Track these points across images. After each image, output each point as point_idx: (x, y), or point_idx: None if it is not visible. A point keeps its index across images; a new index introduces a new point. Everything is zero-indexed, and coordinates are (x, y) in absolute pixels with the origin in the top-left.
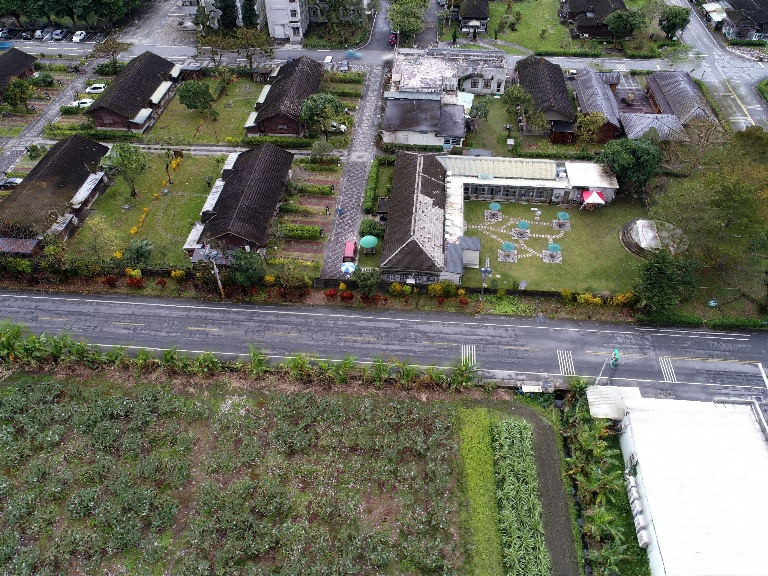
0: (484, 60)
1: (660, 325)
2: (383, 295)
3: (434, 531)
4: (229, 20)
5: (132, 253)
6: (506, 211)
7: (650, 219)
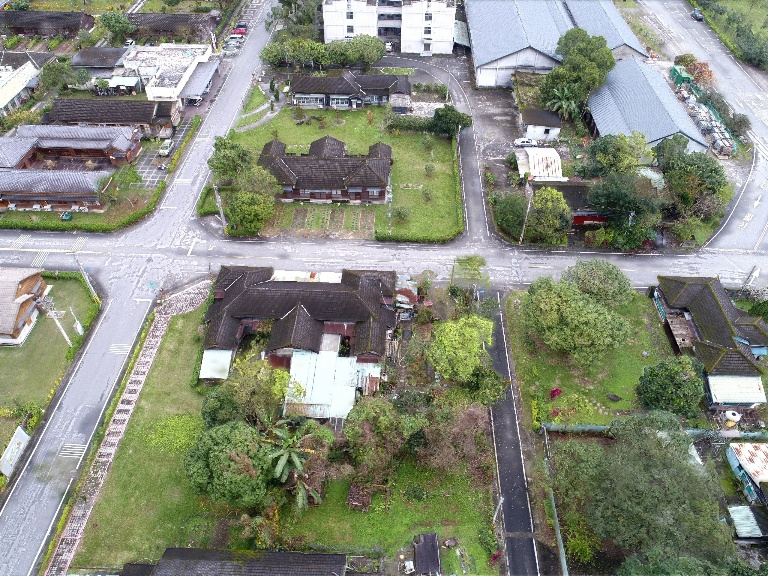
0: None
1: None
2: None
3: None
4: None
5: None
6: None
7: None
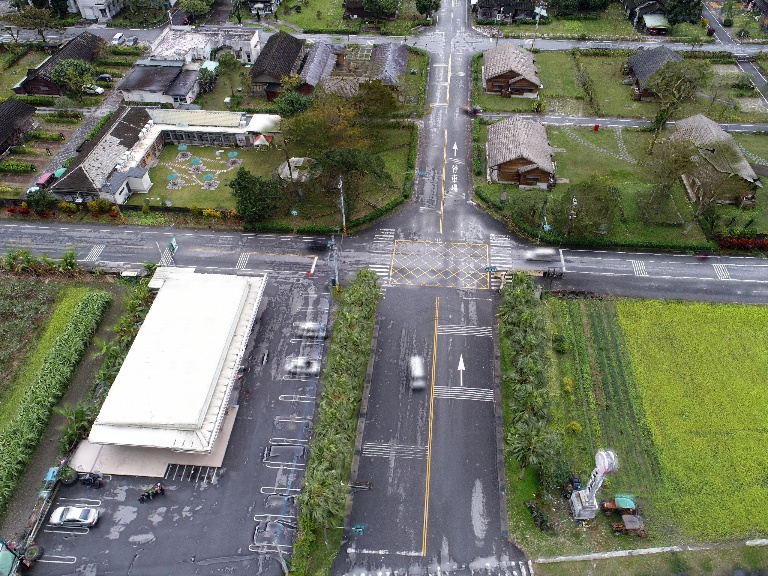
0: (240, 35)
1: (259, 231)
2: (58, 212)
3: (1, 363)
4: (38, 2)
5: None
6: (197, 153)
7: (302, 157)
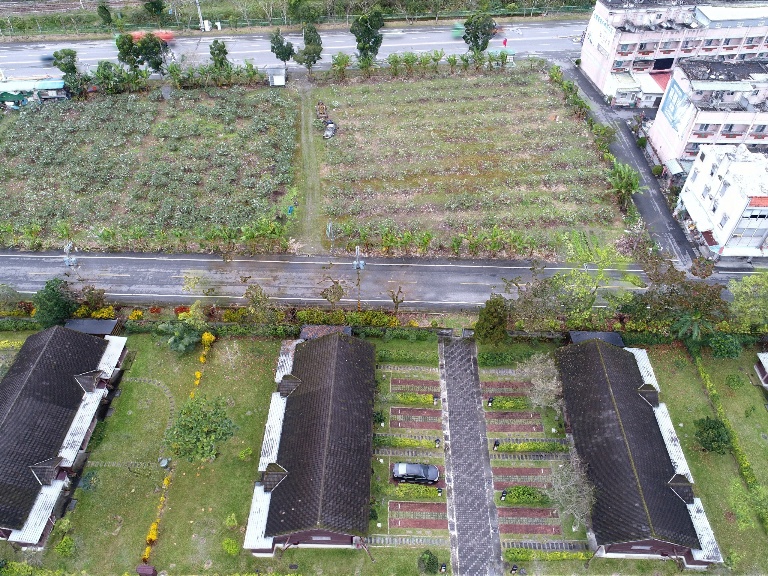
0: None
1: None
2: None
3: None
4: None
5: (186, 329)
6: None
7: None
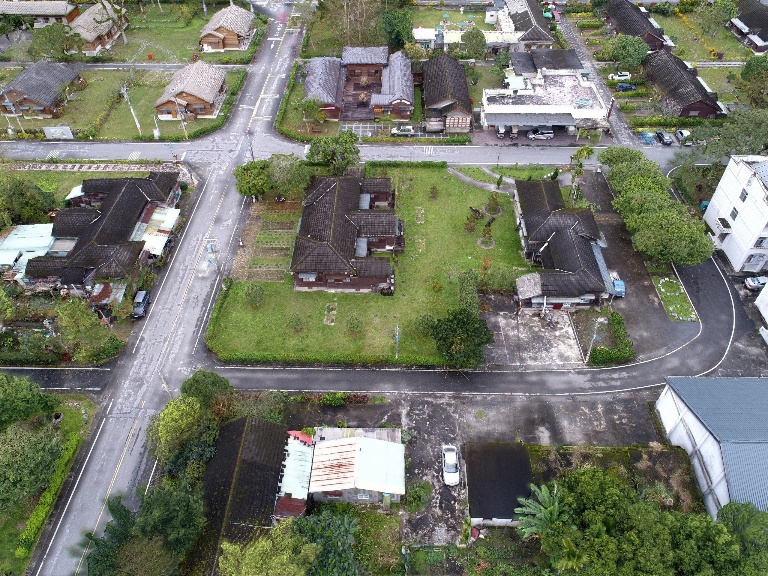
0: None
1: None
2: None
3: None
4: None
5: (668, 5)
6: None
7: None
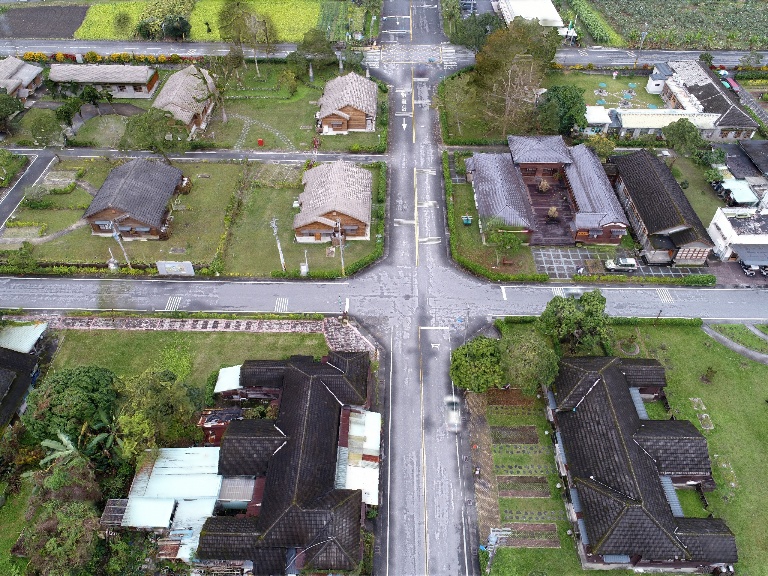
0: None
1: None
2: None
3: None
4: None
5: None
6: None
7: None
